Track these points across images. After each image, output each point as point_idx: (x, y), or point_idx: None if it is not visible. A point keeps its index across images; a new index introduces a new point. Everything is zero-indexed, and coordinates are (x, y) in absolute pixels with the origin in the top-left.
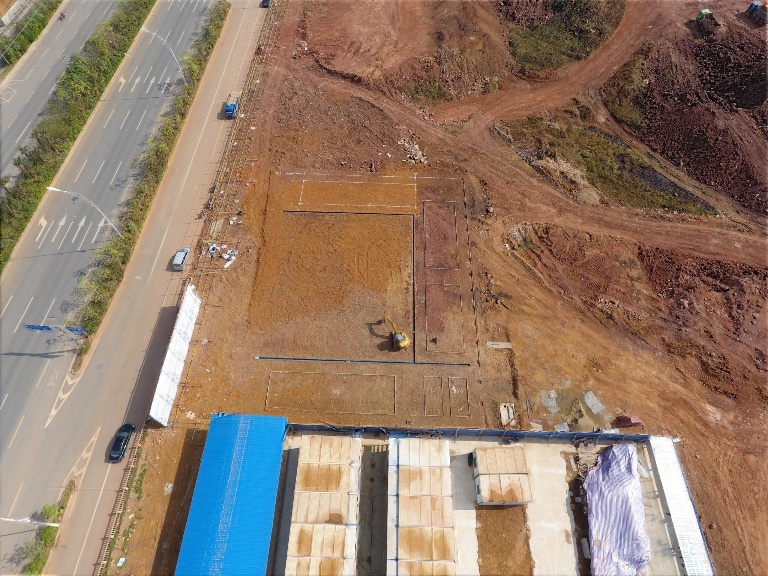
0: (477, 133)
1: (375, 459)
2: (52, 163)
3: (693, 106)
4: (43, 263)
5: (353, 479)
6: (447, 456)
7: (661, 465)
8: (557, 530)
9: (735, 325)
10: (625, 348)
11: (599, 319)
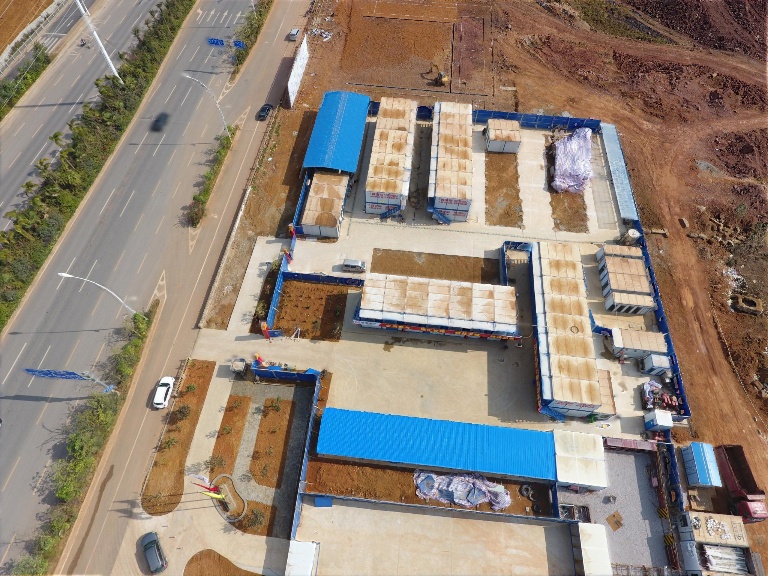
0: None
1: (423, 129)
2: None
3: None
4: (203, 31)
5: (412, 116)
6: (470, 110)
7: (605, 134)
8: (535, 164)
9: (672, 87)
10: (593, 93)
11: (578, 80)
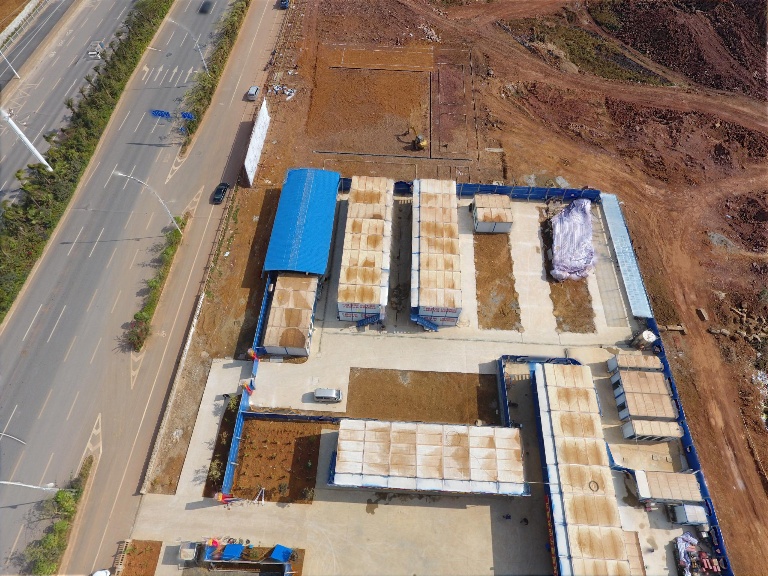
0: (482, 25)
1: (402, 207)
2: (150, 29)
3: (659, 8)
4: (150, 93)
5: (389, 199)
6: (454, 189)
7: (606, 207)
8: (530, 246)
9: (673, 141)
10: (588, 153)
11: (570, 136)
